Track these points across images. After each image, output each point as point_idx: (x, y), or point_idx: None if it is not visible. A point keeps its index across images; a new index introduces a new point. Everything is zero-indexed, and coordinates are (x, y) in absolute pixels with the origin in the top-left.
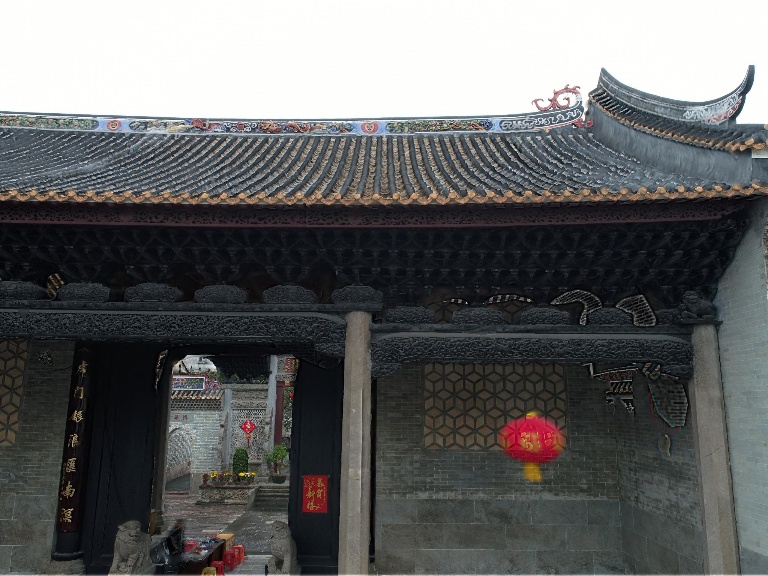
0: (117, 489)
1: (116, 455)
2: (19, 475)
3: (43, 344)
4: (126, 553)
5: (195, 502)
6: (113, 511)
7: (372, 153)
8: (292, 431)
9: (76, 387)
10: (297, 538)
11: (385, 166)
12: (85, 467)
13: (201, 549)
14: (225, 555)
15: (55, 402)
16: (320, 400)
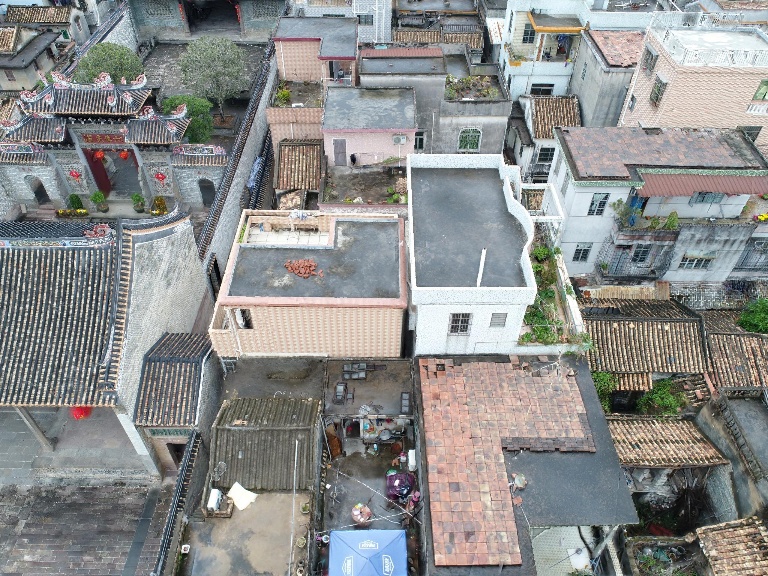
0: None
1: None
2: None
3: None
4: None
5: None
6: None
7: (2, 280)
8: None
9: None
10: None
11: (6, 303)
12: None
13: None
14: None
15: None
16: None
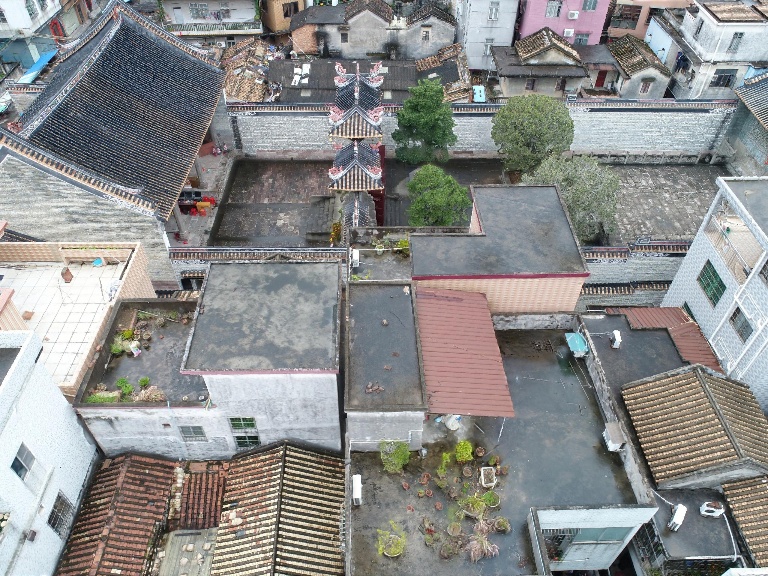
0: None
1: None
2: None
3: None
4: None
5: None
6: None
7: None
8: None
9: None
10: None
11: None
12: None
13: None
14: None
15: None
16: None
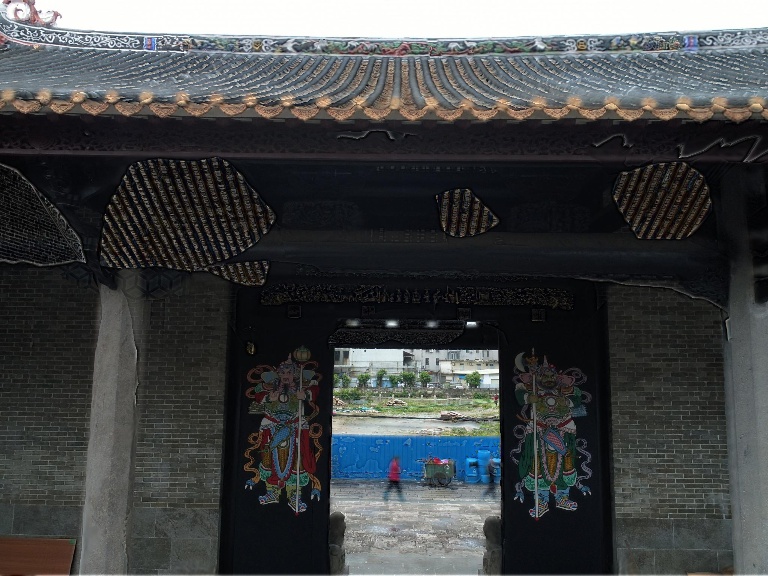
0: None
1: None
2: None
3: None
4: None
5: None
6: None
7: None
8: None
9: None
10: None
11: None
12: None
13: None
14: None
15: None
16: None
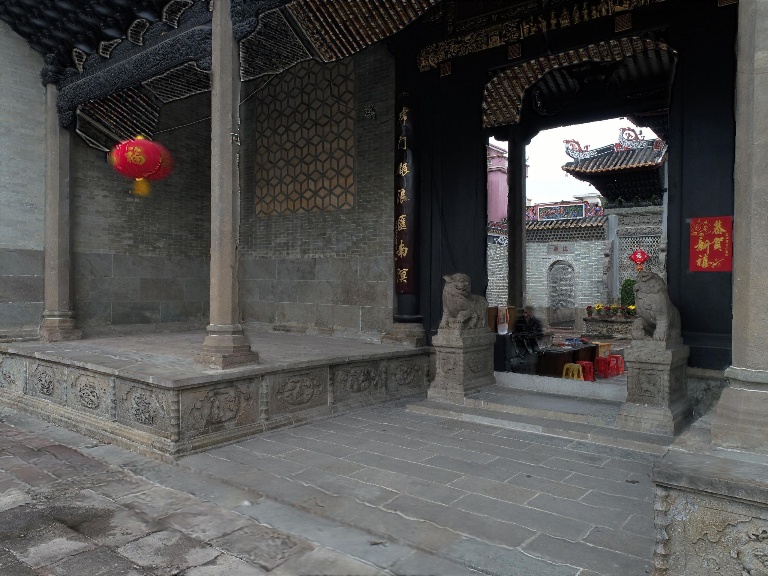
0: (449, 249)
1: (446, 212)
2: (359, 237)
3: (367, 98)
4: (455, 308)
5: (580, 336)
6: (448, 274)
7: None
8: (669, 156)
9: (399, 137)
10: (682, 308)
11: None
12: (416, 225)
13: (564, 345)
14: (597, 360)
15: (382, 158)
16: (716, 102)
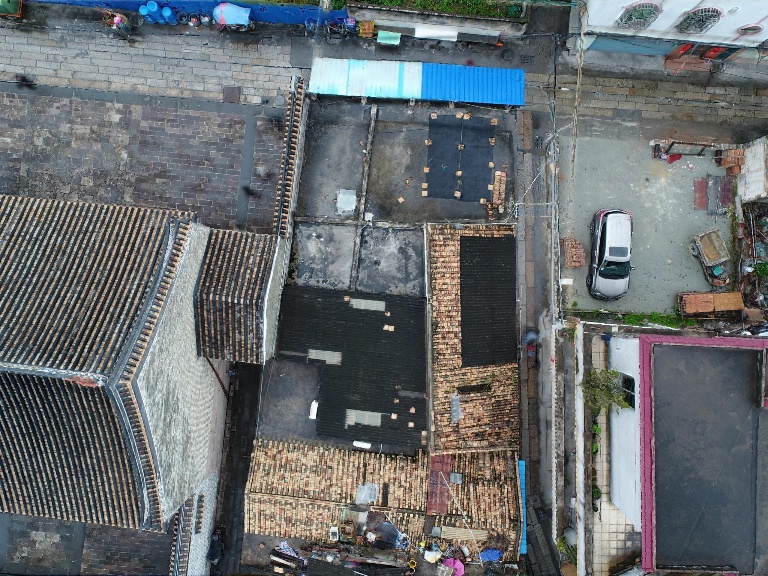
0: None
1: None
2: None
3: None
4: None
5: None
6: None
7: None
8: None
9: None
10: None
11: None
12: None
13: None
14: None
15: None
16: None
